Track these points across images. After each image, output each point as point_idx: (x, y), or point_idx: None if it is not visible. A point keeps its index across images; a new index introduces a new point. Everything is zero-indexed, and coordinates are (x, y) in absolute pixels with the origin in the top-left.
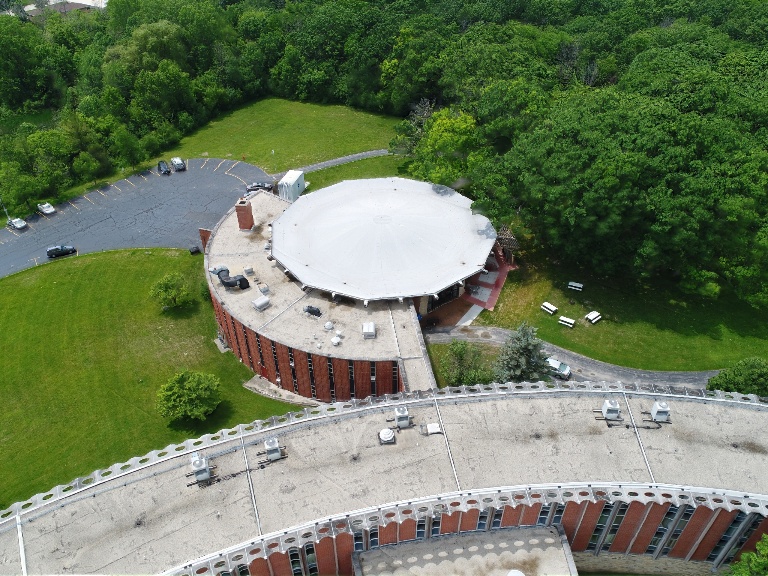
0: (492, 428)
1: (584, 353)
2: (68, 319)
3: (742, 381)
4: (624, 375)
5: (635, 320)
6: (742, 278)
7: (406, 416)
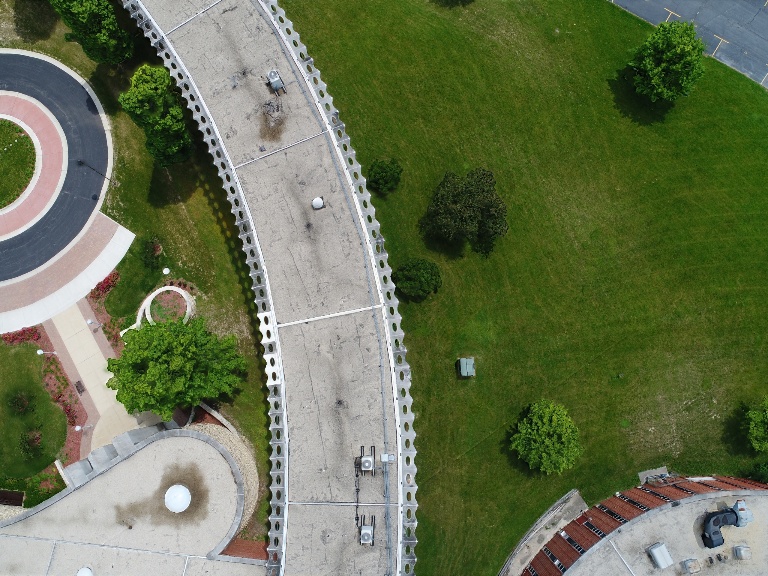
0: None
1: None
2: (766, 290)
3: None
4: None
5: None
6: None
7: None
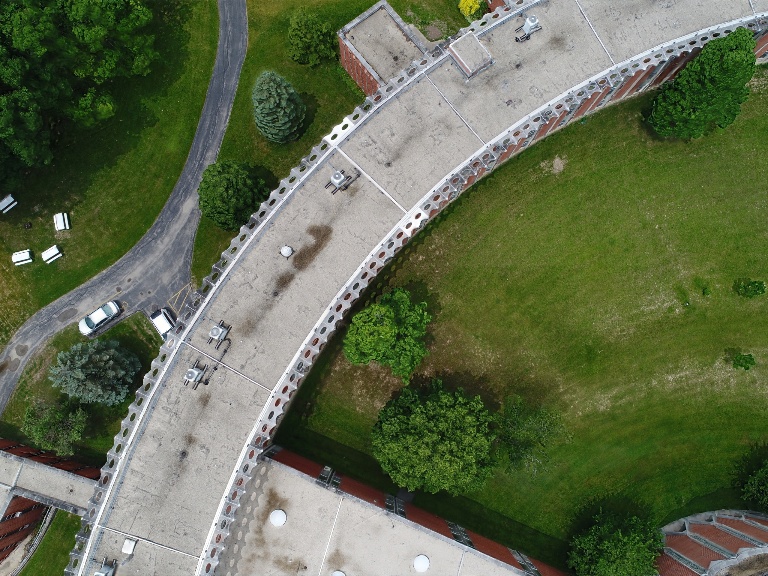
0: (155, 490)
1: (100, 268)
2: None
3: (222, 205)
4: (146, 252)
5: (89, 181)
6: (112, 74)
7: (105, 575)
